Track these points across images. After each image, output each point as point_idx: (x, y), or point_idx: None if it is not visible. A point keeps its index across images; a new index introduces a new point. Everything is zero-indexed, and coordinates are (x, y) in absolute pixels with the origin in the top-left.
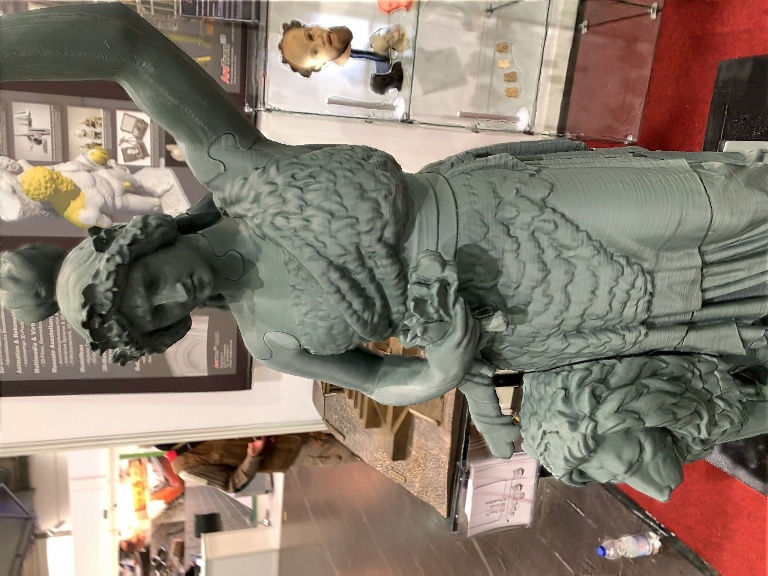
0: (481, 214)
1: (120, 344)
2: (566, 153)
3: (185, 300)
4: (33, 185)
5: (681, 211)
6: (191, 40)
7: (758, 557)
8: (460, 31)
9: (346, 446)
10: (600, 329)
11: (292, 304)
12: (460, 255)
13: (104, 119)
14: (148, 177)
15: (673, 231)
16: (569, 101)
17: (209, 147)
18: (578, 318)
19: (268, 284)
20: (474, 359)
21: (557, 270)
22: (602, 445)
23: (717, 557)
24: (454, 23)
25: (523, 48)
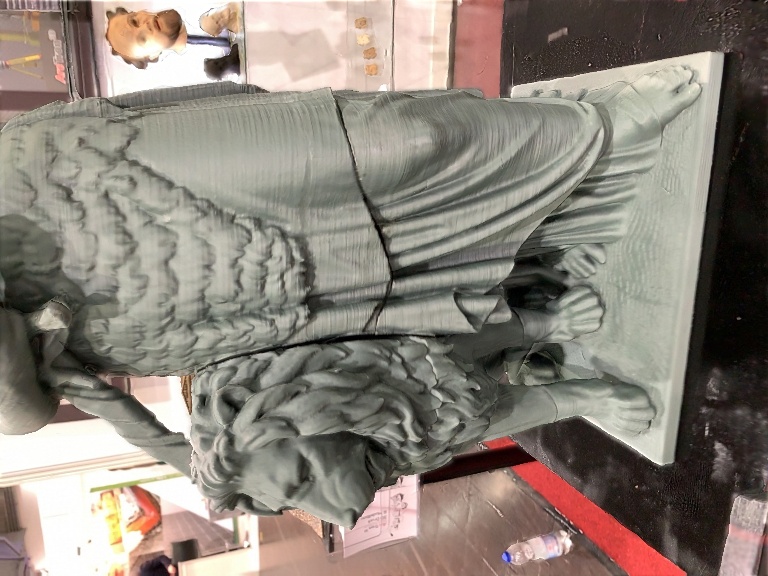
0: (26, 174)
1: None
2: (215, 97)
3: None
4: None
5: (306, 152)
6: (15, 38)
7: None
8: (325, 11)
9: None
10: (241, 315)
11: None
12: None
13: None
14: None
15: (303, 179)
16: (453, 78)
17: None
18: (196, 303)
19: None
20: (54, 368)
21: (148, 241)
22: (248, 465)
23: (621, 553)
24: (317, 3)
25: (398, 26)
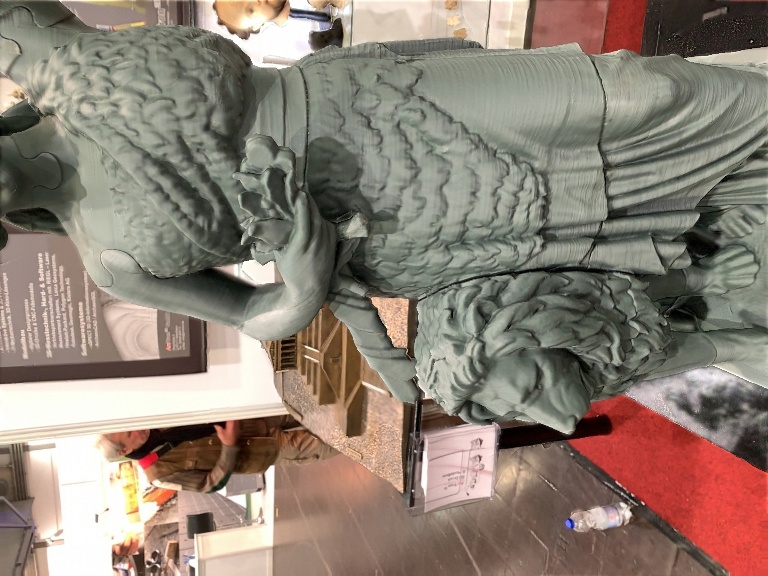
0: (335, 103)
1: None
2: (453, 50)
3: None
4: None
5: (569, 96)
6: (123, 5)
7: (726, 520)
8: None
9: (304, 426)
10: (488, 240)
11: (114, 211)
12: (312, 151)
13: None
14: None
15: (562, 120)
16: None
17: None
18: (459, 225)
19: (90, 191)
20: (340, 274)
21: (429, 168)
22: (493, 370)
23: (686, 524)
24: None
25: (478, 9)
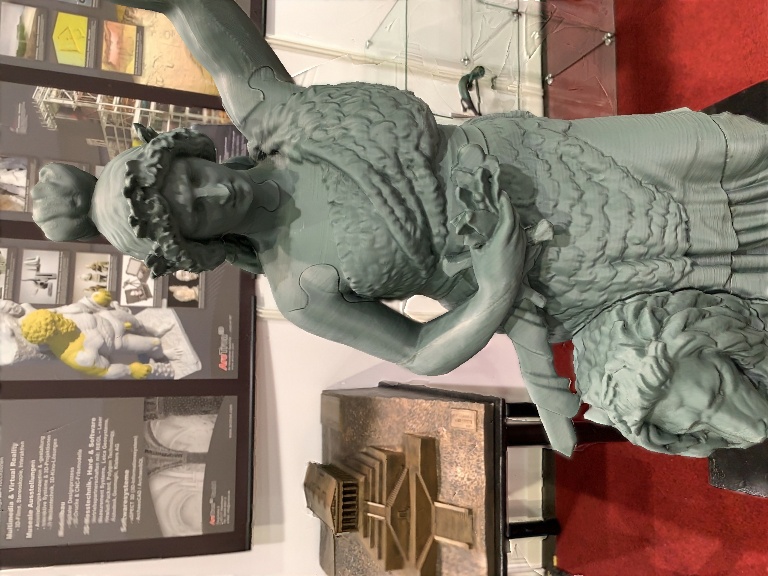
0: (509, 141)
1: (158, 231)
2: None
3: (226, 197)
4: (33, 328)
5: (696, 135)
6: None
7: None
8: None
9: None
10: (645, 259)
11: (332, 221)
12: None
13: (111, 264)
14: (150, 317)
15: (693, 155)
16: None
17: (249, 78)
18: (621, 241)
19: (305, 211)
20: (523, 283)
21: (591, 191)
22: (677, 371)
23: None
24: None
25: None
